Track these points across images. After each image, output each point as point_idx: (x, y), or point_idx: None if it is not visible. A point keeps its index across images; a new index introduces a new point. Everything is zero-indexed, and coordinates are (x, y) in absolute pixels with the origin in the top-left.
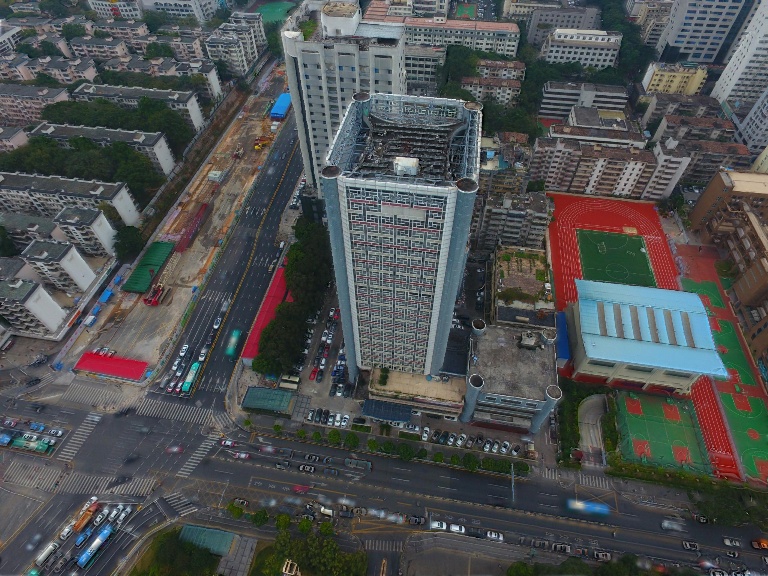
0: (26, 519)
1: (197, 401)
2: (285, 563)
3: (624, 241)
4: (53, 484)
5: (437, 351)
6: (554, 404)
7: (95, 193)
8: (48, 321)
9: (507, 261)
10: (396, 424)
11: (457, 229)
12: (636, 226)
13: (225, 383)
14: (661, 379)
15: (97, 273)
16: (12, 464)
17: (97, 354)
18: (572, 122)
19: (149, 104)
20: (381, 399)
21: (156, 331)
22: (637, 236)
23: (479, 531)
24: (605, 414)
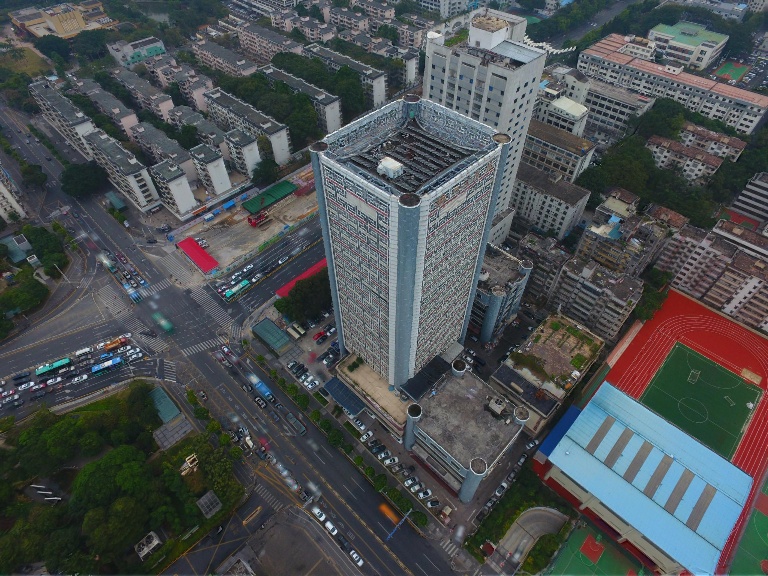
0: (90, 323)
1: (230, 308)
2: (192, 455)
3: (732, 384)
4: (117, 311)
5: (396, 364)
6: (476, 479)
7: (263, 126)
8: (181, 203)
9: (553, 330)
10: (348, 412)
11: (400, 241)
12: (764, 376)
13: (256, 306)
14: (640, 543)
15: (233, 185)
16: (108, 286)
17: (197, 242)
18: (766, 228)
19: (345, 72)
20: (345, 383)
21: (242, 245)
22: (756, 387)
23: (346, 544)
24: (549, 534)
